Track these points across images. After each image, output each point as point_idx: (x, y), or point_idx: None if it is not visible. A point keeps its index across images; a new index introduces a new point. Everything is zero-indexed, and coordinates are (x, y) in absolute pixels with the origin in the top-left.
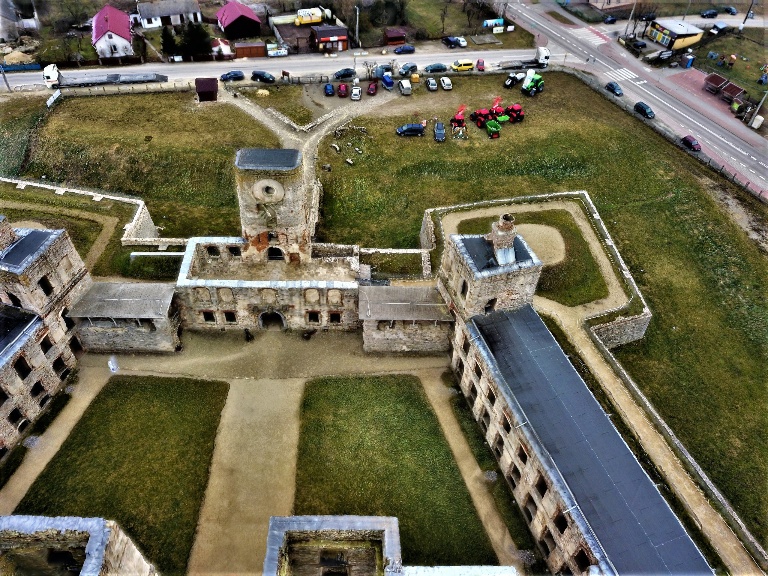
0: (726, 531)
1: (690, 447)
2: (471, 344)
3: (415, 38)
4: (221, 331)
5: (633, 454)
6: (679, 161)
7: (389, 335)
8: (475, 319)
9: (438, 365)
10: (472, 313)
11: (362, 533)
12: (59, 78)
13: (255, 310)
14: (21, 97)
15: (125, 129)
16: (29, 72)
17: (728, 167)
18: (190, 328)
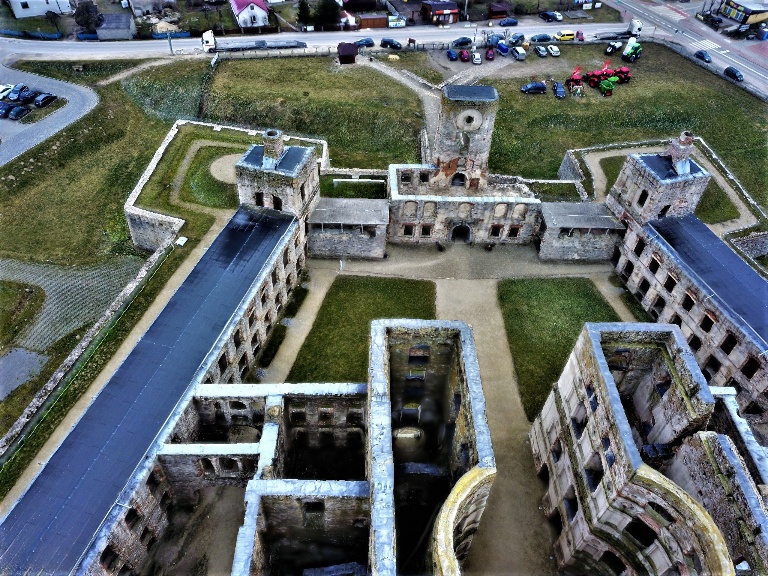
0: None
1: None
2: (648, 243)
3: (514, 13)
4: (416, 243)
5: None
6: None
7: (566, 243)
8: (651, 223)
9: (604, 270)
10: (649, 218)
11: (653, 335)
12: (215, 43)
13: (452, 223)
14: (183, 59)
15: (283, 86)
16: (182, 39)
17: None
18: (390, 241)
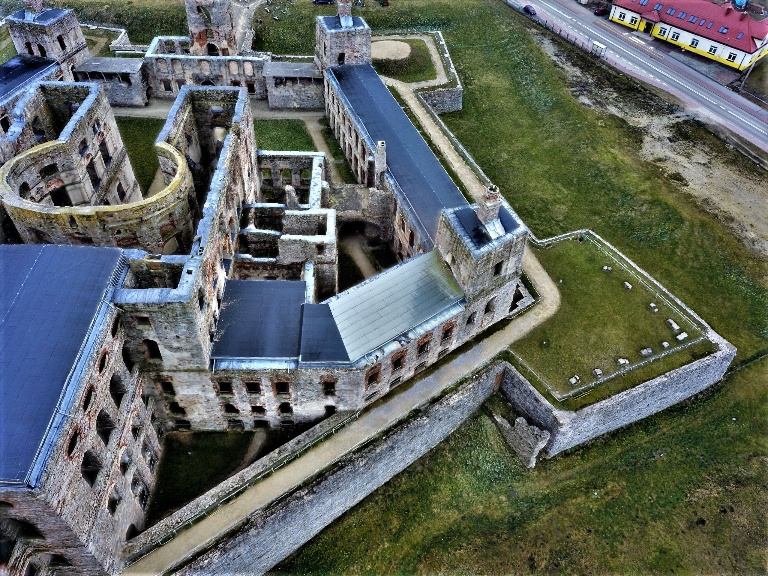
0: (470, 172)
1: (474, 157)
2: (329, 83)
3: None
4: None
5: None
6: (518, 20)
7: (284, 92)
8: (332, 68)
9: (317, 115)
10: (329, 64)
11: (229, 94)
12: None
13: (197, 78)
14: None
15: None
16: None
17: None
18: (155, 96)
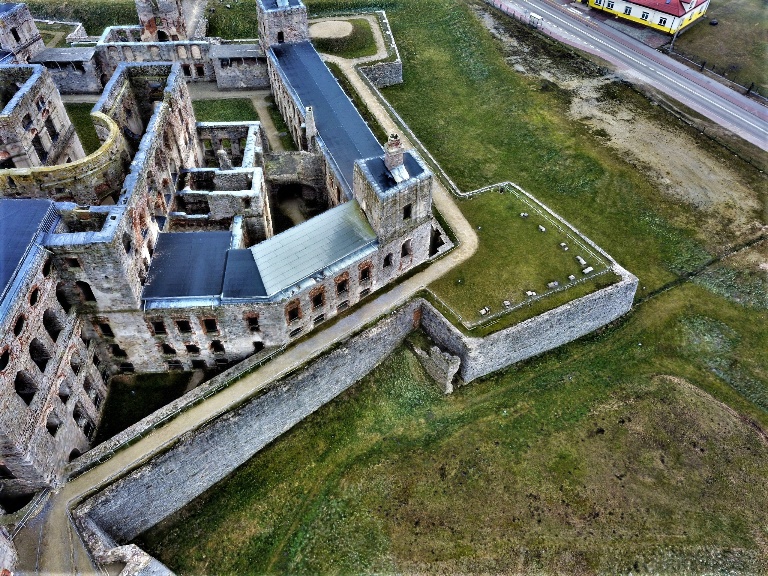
0: (402, 136)
1: (412, 125)
2: (270, 61)
3: None
4: None
5: None
6: None
7: (230, 73)
8: (272, 46)
9: (264, 93)
10: (269, 42)
11: (163, 69)
12: None
13: None
14: None
15: None
16: None
17: None
18: None
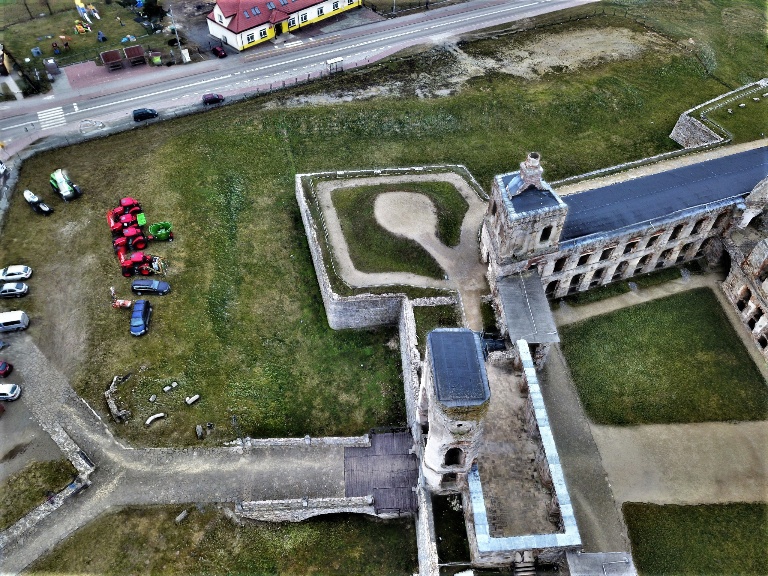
0: (641, 169)
1: None
2: None
3: None
4: None
5: None
6: (238, 113)
7: None
8: (558, 241)
9: None
10: None
11: None
12: None
13: None
14: None
15: None
16: None
17: (251, 89)
18: None
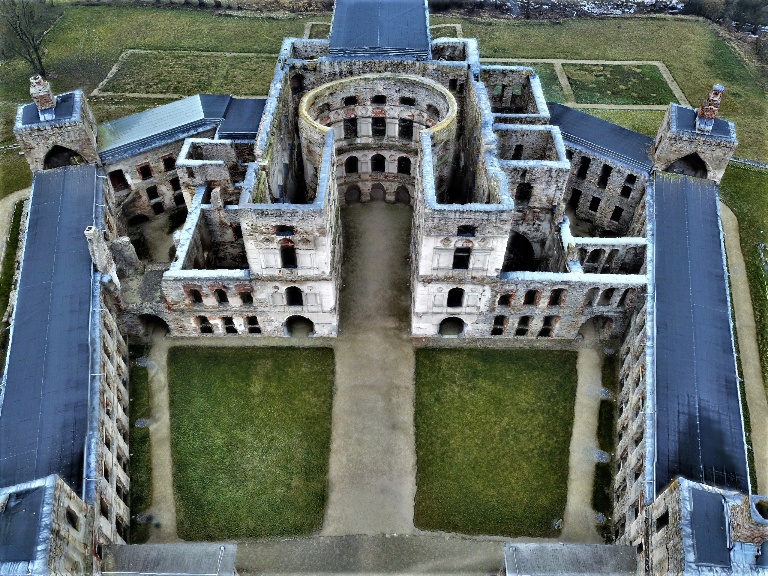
0: None
1: None
2: (100, 487)
3: None
4: None
5: (8, 350)
6: None
7: None
8: None
9: None
10: None
11: None
12: None
13: None
14: None
15: None
16: None
17: None
18: None
